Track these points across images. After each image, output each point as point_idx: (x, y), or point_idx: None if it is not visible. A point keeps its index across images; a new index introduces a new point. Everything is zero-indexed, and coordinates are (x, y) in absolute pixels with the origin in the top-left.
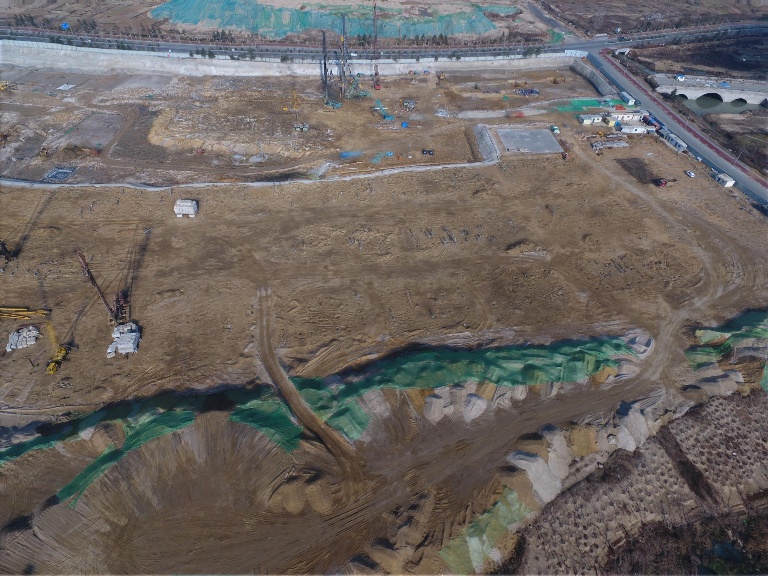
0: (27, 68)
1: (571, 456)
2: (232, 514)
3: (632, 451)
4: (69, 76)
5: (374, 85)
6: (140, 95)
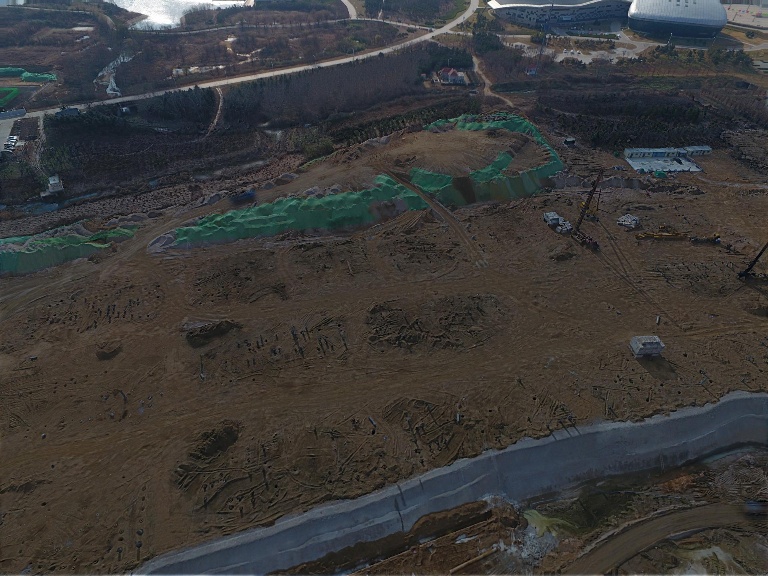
0: None
1: None
2: (430, 153)
3: None
4: None
5: None
6: None
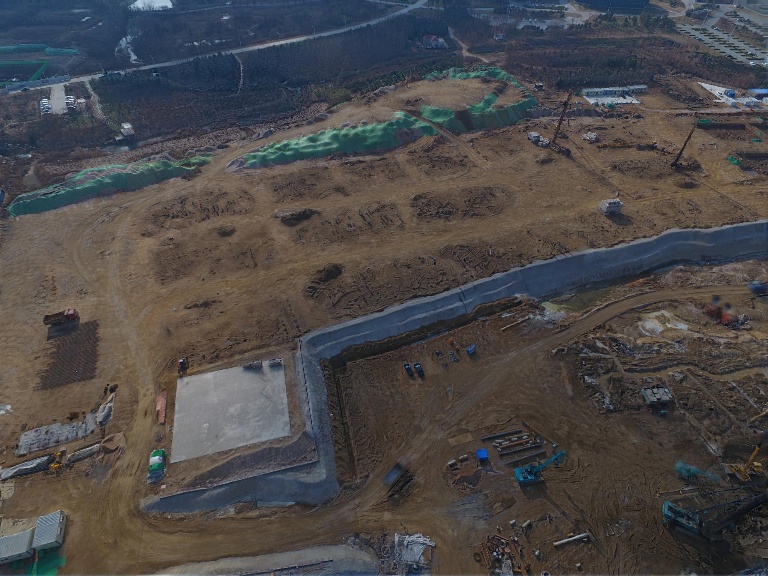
0: None
1: None
2: (432, 95)
3: None
4: None
5: None
6: None
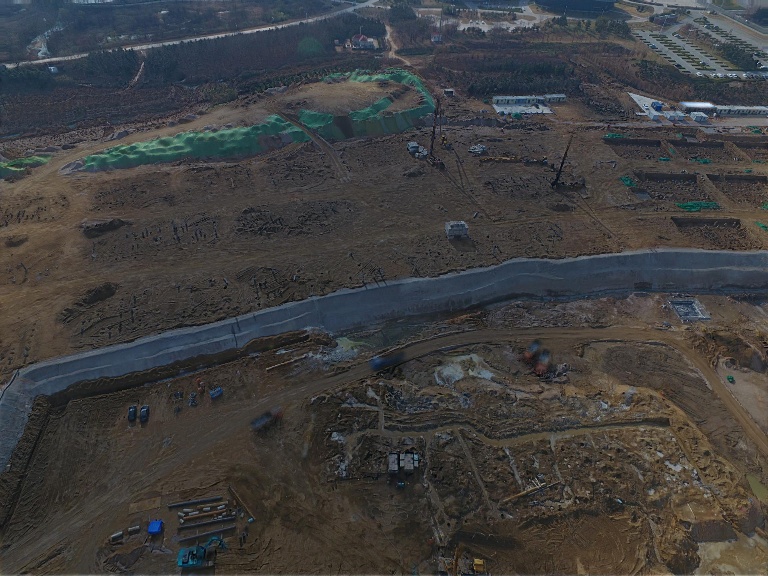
0: None
1: None
2: None
3: None
4: None
5: None
6: None
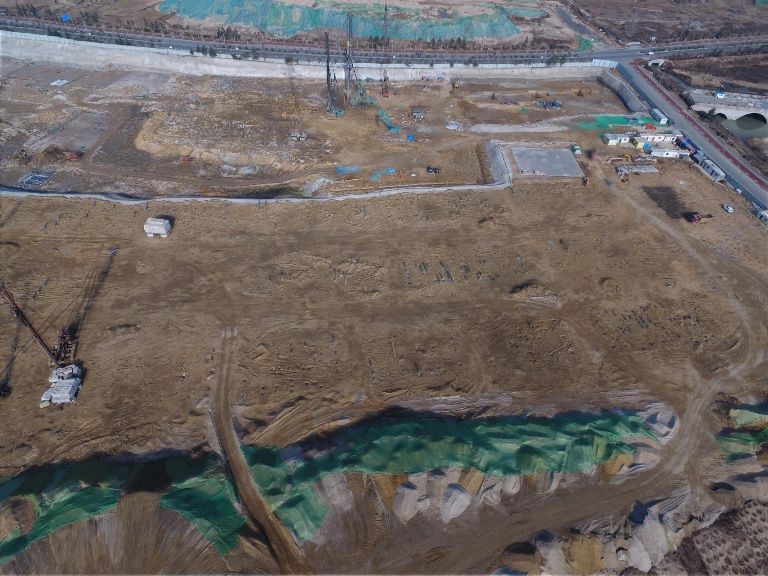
0: (23, 61)
1: (570, 575)
2: None
3: (646, 571)
4: (65, 71)
5: (382, 92)
6: (134, 94)
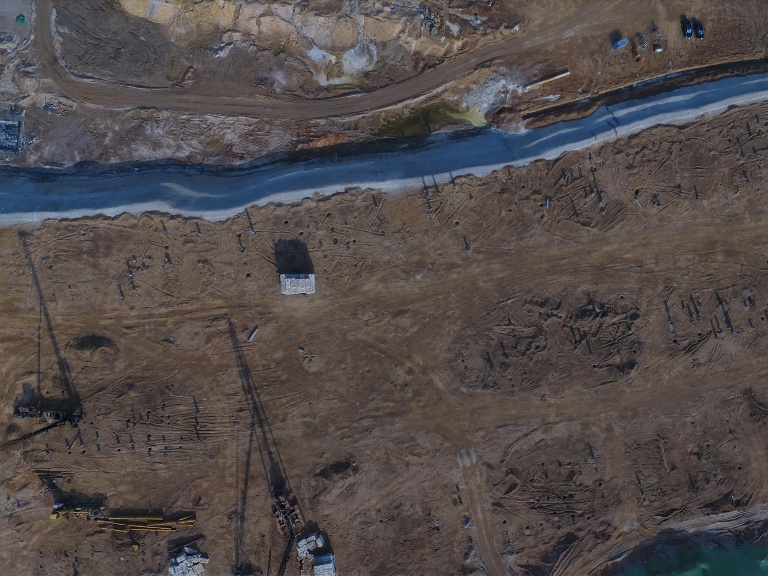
0: None
1: None
2: None
3: None
4: None
5: None
6: None
